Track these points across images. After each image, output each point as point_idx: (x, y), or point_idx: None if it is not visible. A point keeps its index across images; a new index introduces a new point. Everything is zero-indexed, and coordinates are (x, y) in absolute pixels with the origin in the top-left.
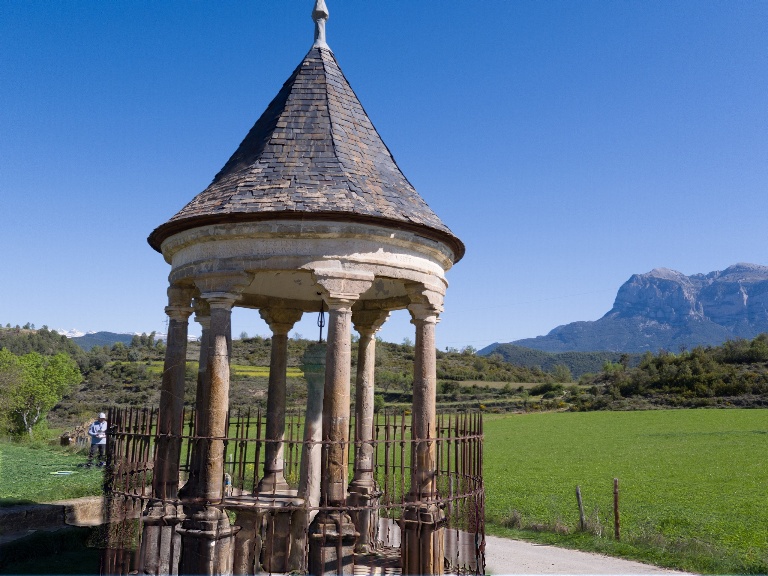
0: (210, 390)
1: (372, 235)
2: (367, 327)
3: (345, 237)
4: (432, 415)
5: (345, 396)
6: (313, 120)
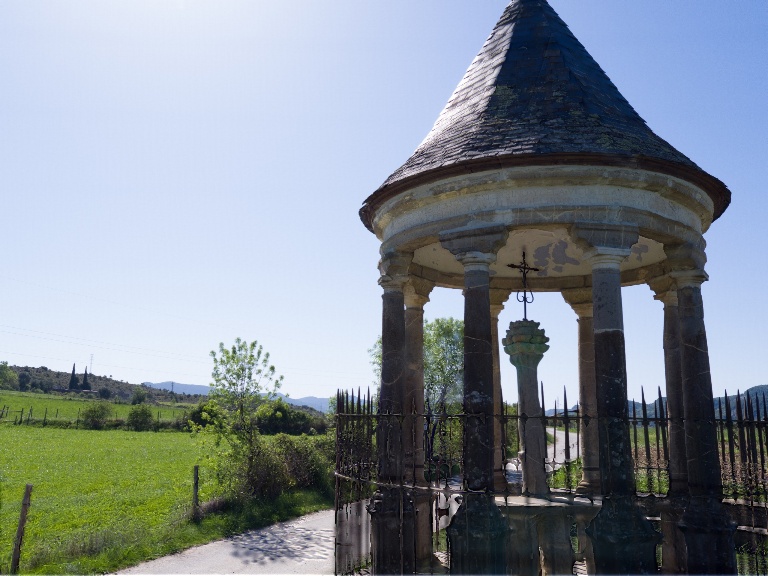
0: None
1: None
2: None
3: None
4: None
5: None
6: None
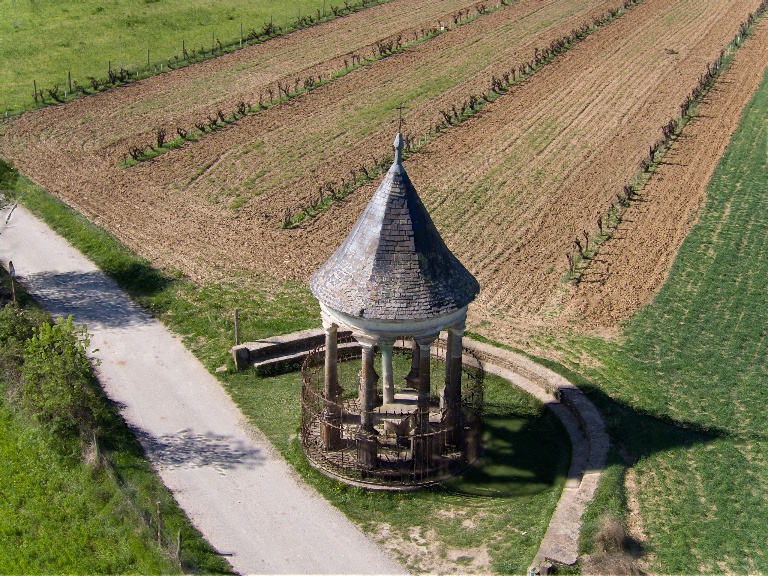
0: None
1: None
2: None
3: None
4: None
5: None
6: None
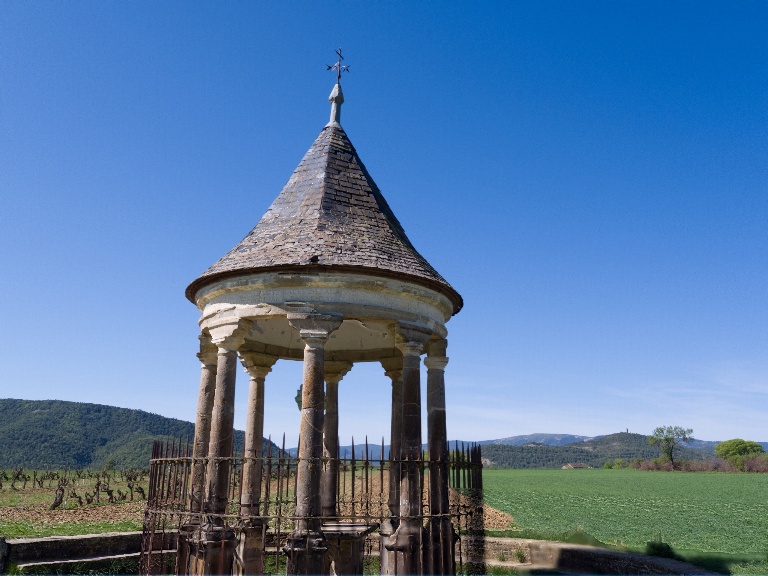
0: None
1: None
2: None
3: None
4: None
5: None
6: None
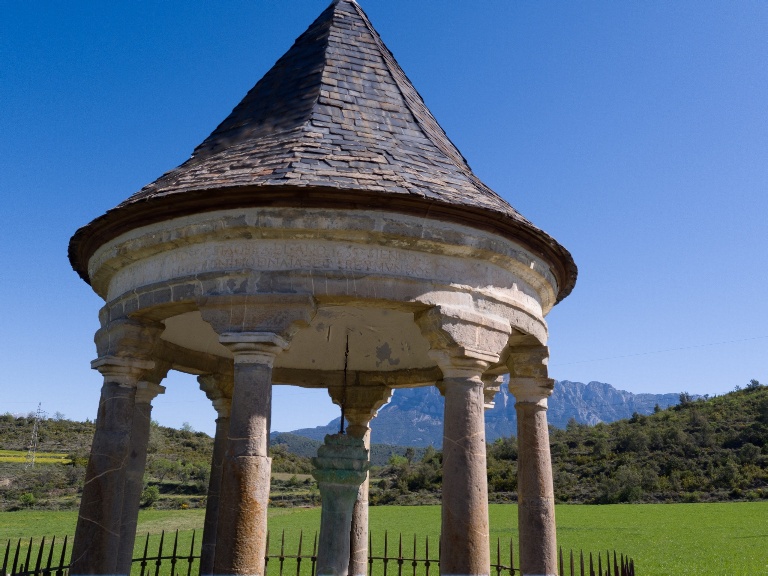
0: (235, 527)
1: (512, 259)
2: (363, 411)
3: (477, 257)
4: (555, 559)
5: (487, 536)
6: (374, 84)
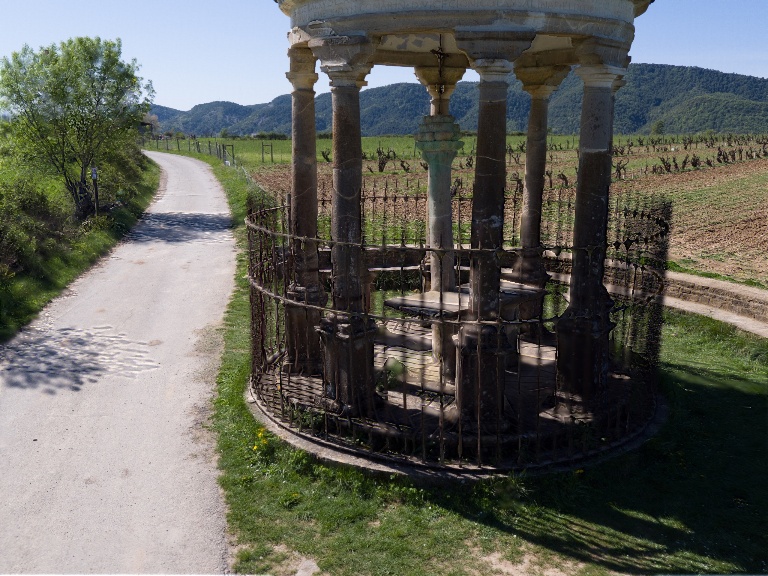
0: None
1: None
2: None
3: None
4: None
5: None
6: None
